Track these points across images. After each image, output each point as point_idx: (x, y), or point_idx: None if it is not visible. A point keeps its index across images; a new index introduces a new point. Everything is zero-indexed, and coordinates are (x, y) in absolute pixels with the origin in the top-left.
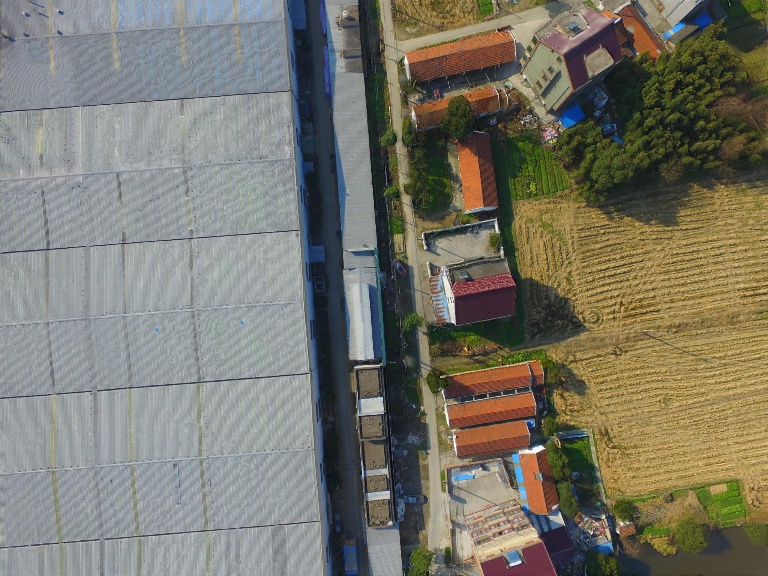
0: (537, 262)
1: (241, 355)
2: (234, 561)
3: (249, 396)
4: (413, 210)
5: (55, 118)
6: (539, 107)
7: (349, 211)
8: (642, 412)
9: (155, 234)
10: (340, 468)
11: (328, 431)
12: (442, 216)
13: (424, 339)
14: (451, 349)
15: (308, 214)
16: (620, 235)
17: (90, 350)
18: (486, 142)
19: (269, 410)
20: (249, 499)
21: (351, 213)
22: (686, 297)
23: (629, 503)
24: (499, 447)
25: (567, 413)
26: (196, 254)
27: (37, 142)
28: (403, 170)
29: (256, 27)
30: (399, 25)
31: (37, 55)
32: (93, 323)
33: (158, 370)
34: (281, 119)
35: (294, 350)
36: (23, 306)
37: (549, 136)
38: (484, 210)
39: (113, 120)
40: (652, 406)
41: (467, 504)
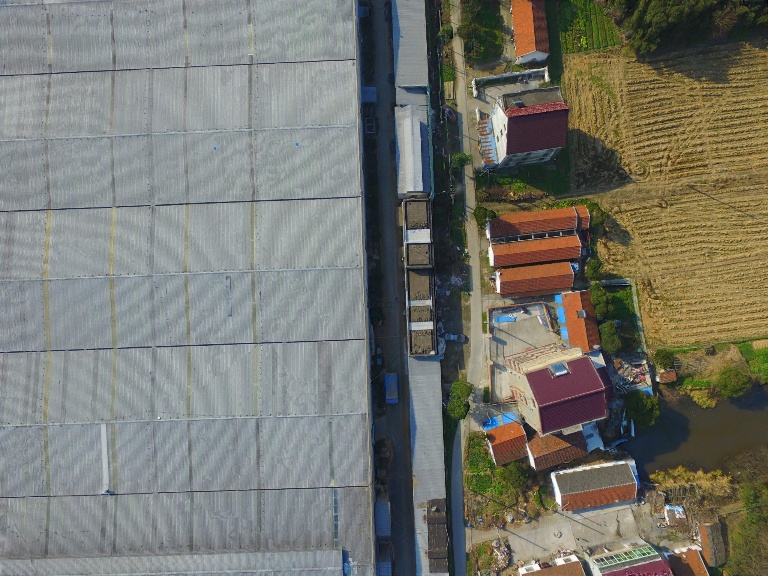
0: (585, 114)
1: (295, 176)
2: (280, 374)
3: (301, 215)
4: (464, 59)
5: None
6: None
7: (402, 52)
8: (686, 264)
9: (216, 59)
10: (383, 305)
11: (373, 269)
12: (492, 66)
13: (470, 184)
14: (497, 193)
15: (361, 60)
16: (669, 90)
17: (150, 165)
18: None
19: (320, 229)
20: (297, 314)
21: (404, 54)
22: (734, 153)
23: (670, 353)
24: (542, 286)
25: (610, 262)
26: (255, 79)
27: None
28: (455, 20)
29: None
30: None
31: None
32: (154, 139)
33: (214, 187)
34: None
35: (346, 173)
36: (89, 121)
37: None
38: (535, 59)
39: None
40: (696, 259)
41: (507, 346)
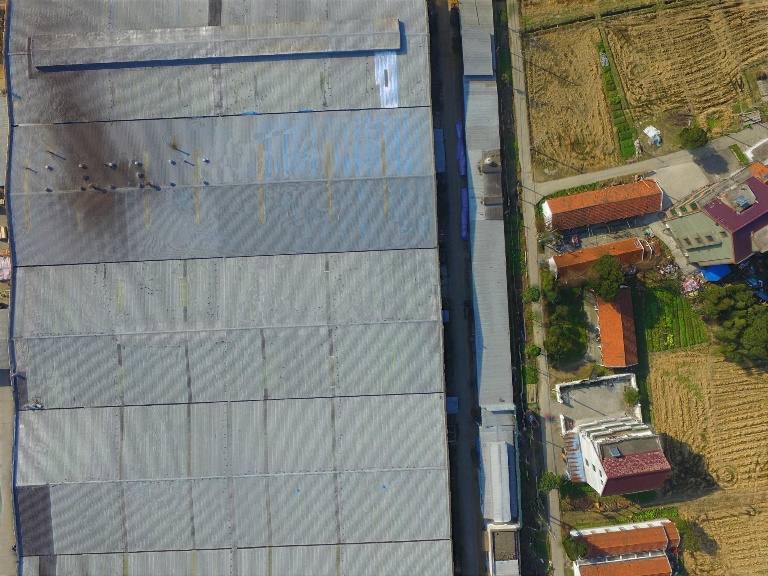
0: (672, 417)
1: (382, 519)
2: None
3: (389, 560)
4: (547, 359)
5: (198, 268)
6: (680, 257)
7: (486, 365)
8: None
9: (297, 391)
10: None
11: None
12: (576, 366)
13: (554, 492)
14: (583, 506)
15: None
16: (758, 392)
17: (231, 508)
18: (628, 297)
19: (409, 575)
20: None
21: (488, 367)
22: None
23: None
24: None
25: (697, 573)
26: (338, 414)
27: (181, 294)
28: (537, 318)
29: (404, 182)
30: (537, 166)
31: (182, 204)
32: (235, 482)
33: (298, 530)
34: (427, 278)
35: (435, 515)
36: (166, 461)
37: (690, 288)
38: None
39: (256, 272)
40: None
41: None
